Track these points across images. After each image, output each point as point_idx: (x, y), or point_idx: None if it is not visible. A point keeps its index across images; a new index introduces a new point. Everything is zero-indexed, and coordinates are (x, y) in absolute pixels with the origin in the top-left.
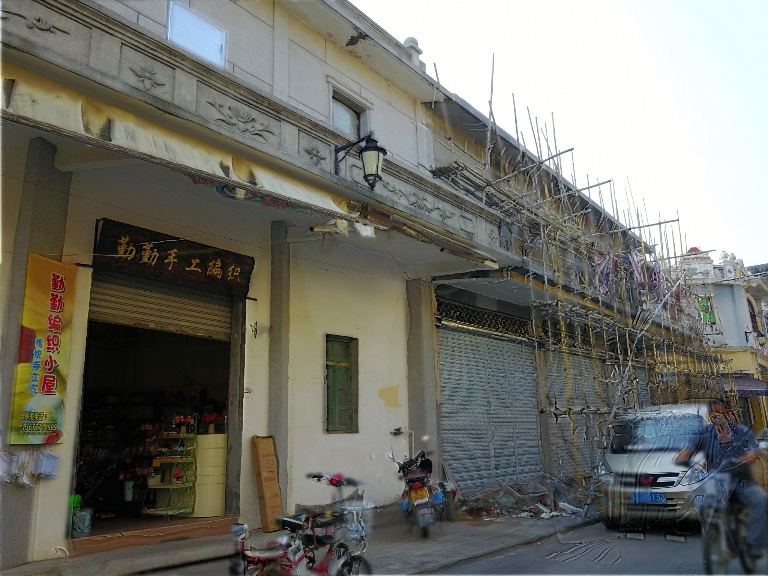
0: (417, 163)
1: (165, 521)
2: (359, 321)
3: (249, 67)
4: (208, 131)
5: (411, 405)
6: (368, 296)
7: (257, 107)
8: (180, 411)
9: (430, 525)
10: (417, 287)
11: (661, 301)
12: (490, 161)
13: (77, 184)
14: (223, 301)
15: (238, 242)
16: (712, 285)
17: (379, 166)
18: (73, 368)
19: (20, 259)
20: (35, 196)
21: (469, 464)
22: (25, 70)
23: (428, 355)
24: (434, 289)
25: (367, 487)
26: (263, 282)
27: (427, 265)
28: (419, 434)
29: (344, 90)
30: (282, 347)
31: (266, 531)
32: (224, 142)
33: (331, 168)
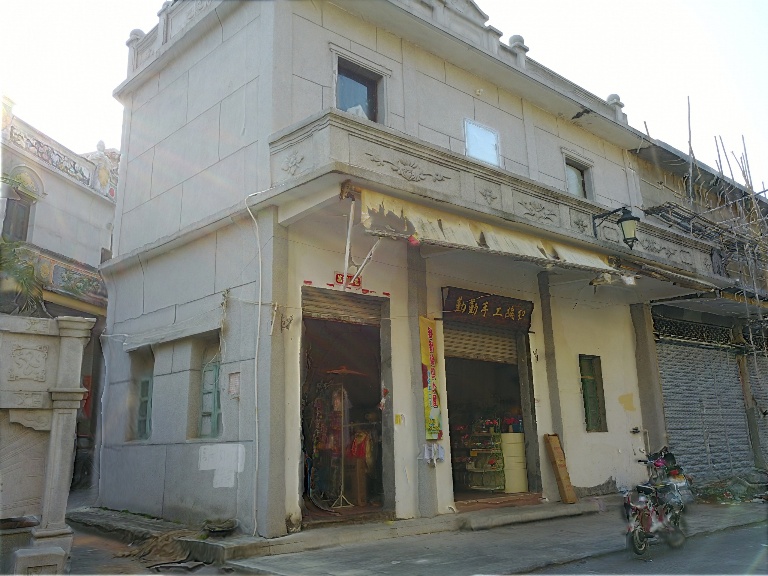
0: (629, 204)
1: (491, 494)
2: (599, 342)
3: (513, 156)
4: (530, 227)
5: (643, 409)
6: (603, 321)
7: (544, 198)
8: (485, 416)
9: (690, 503)
10: (640, 310)
11: None
12: (686, 188)
13: (429, 264)
14: (510, 335)
15: (522, 292)
16: None
17: (635, 231)
18: (442, 389)
19: (414, 320)
20: (417, 278)
21: (690, 458)
22: (444, 212)
23: (654, 367)
24: (650, 309)
25: (618, 475)
26: (537, 319)
27: (648, 291)
28: (653, 433)
29: (573, 156)
30: (555, 367)
31: (566, 503)
32: (537, 232)
33: (591, 232)
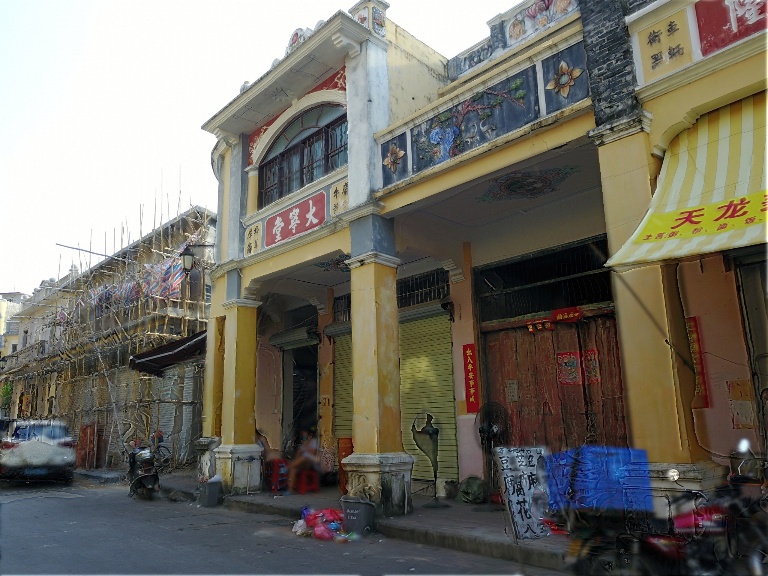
0: None
1: None
2: None
3: None
4: (1, 373)
5: None
6: None
7: None
8: None
9: None
10: None
11: None
12: None
13: None
14: None
15: None
16: None
17: None
18: None
19: None
20: None
21: None
22: None
23: None
24: None
25: None
26: None
27: None
28: None
29: None
30: None
31: None
32: (3, 373)
33: None
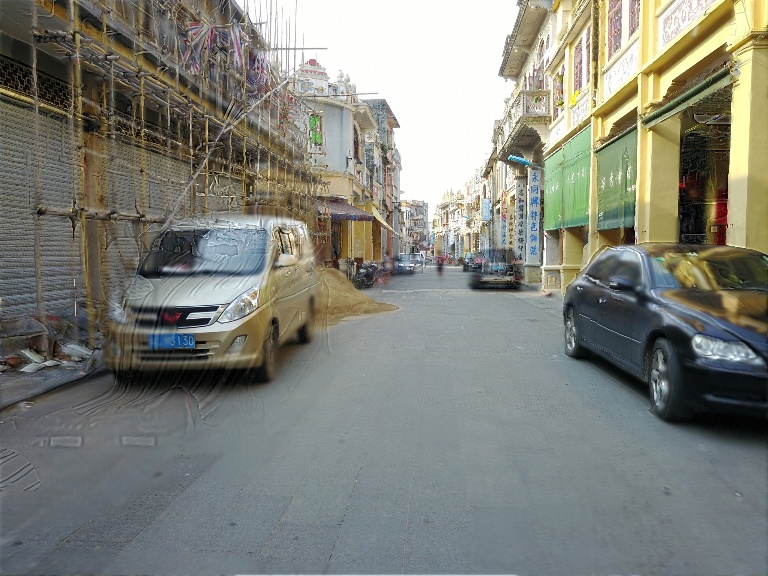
0: None
1: None
2: None
3: None
4: None
5: None
6: None
7: None
8: None
9: None
10: None
11: (261, 97)
12: None
13: None
14: None
15: None
16: (325, 104)
17: None
18: None
19: None
20: None
21: None
22: None
23: None
24: None
25: None
26: None
27: None
28: None
29: None
30: None
31: None
32: None
33: None
